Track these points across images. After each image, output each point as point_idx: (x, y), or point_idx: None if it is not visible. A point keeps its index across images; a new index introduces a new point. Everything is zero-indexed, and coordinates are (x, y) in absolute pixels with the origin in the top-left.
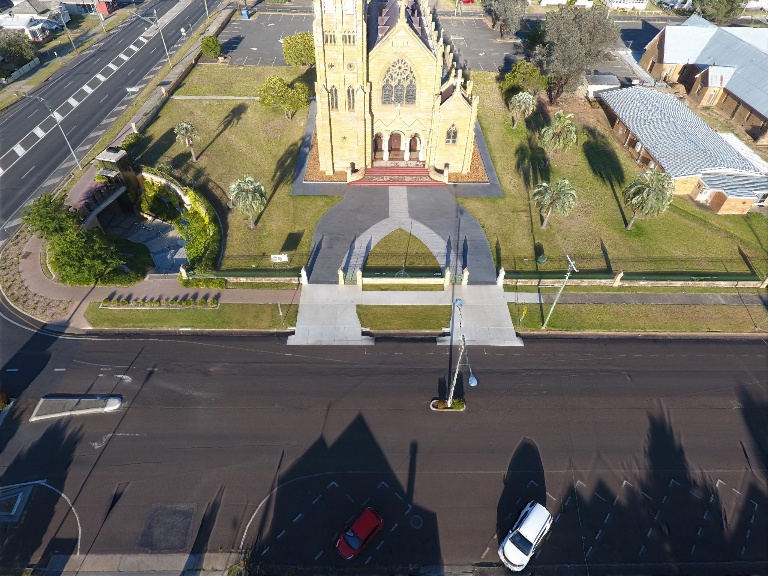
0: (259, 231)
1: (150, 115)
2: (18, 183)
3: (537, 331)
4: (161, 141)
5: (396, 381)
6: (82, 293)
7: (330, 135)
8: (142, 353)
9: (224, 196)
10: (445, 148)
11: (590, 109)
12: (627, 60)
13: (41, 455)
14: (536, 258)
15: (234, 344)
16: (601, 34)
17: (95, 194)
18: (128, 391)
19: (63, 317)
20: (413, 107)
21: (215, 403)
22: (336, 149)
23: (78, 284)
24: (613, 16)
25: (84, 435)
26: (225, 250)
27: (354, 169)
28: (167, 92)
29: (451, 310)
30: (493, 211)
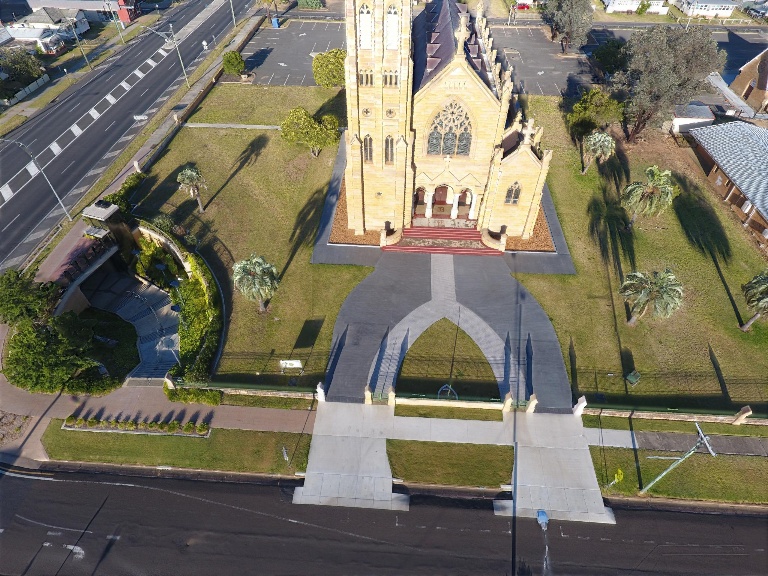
0: (269, 316)
1: (158, 149)
2: None
3: (633, 497)
4: (166, 183)
5: None
6: (44, 404)
7: (362, 191)
8: (104, 507)
9: (231, 262)
10: (503, 209)
11: (676, 148)
12: (715, 82)
13: None
14: (624, 373)
15: (224, 498)
16: (703, 62)
17: None
18: (77, 575)
19: (15, 441)
20: (466, 159)
21: None
22: (368, 206)
23: (41, 390)
24: (692, 25)
25: None
26: (225, 344)
27: (389, 228)
28: (180, 119)
29: (513, 454)
30: (563, 295)
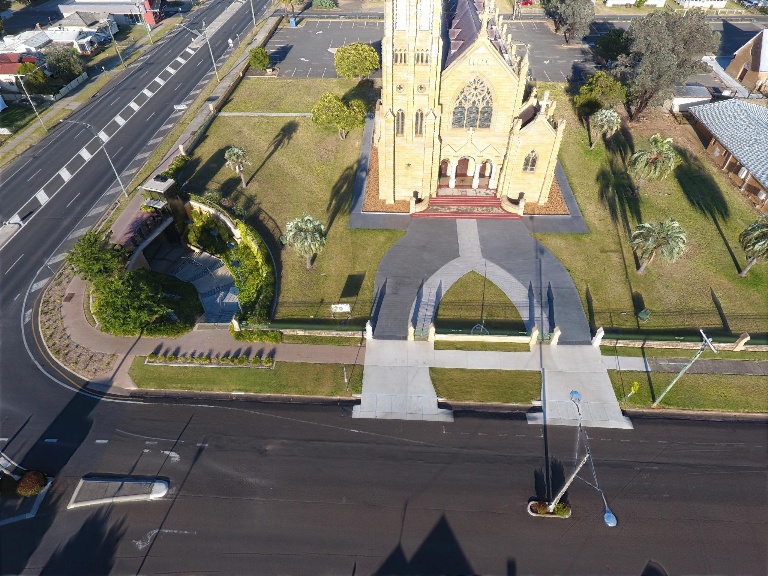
0: (316, 272)
1: (198, 135)
2: (63, 212)
3: (647, 409)
4: (209, 164)
5: (483, 472)
6: (127, 345)
7: (393, 162)
8: (191, 423)
9: (277, 229)
10: (521, 176)
11: (676, 125)
12: None
13: (79, 554)
14: (636, 312)
15: (293, 414)
16: (699, 43)
17: (141, 226)
18: (176, 473)
19: (106, 374)
20: (487, 131)
21: (274, 493)
22: (398, 177)
23: (122, 334)
24: None
25: (127, 530)
26: (279, 295)
27: (417, 198)
28: (215, 109)
29: (541, 377)
30: (578, 251)
